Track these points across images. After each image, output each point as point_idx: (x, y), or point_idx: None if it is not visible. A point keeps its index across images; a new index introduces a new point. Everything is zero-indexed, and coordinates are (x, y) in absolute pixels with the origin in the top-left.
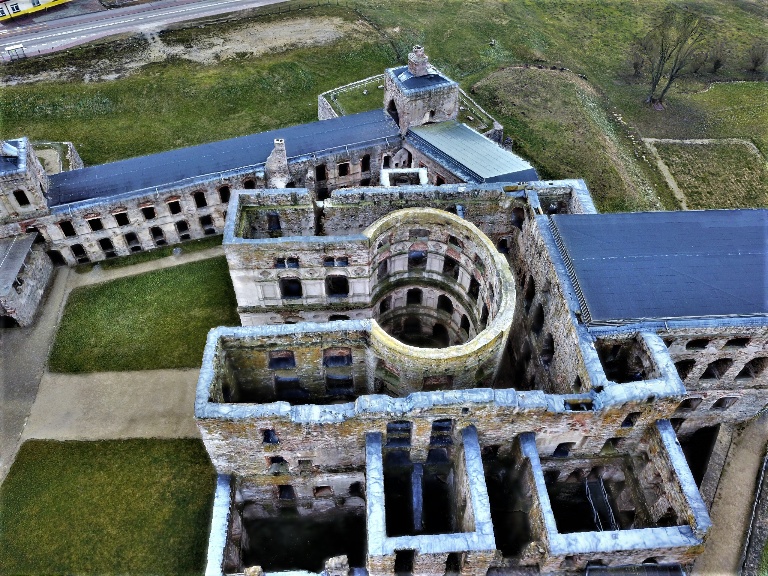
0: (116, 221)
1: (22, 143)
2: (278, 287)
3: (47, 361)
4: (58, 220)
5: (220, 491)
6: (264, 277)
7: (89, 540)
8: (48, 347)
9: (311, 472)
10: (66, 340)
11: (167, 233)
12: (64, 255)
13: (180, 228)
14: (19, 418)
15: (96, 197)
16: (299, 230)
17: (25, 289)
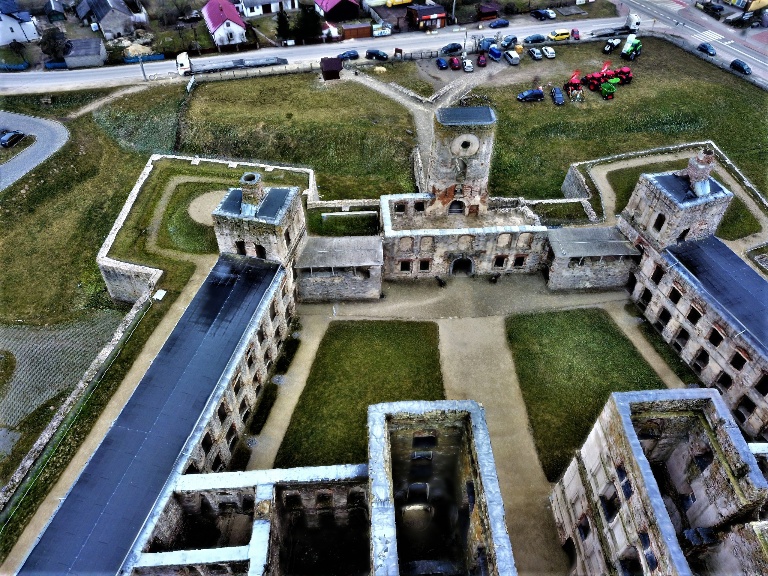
0: (689, 312)
1: (722, 194)
2: (608, 486)
3: (516, 314)
4: (659, 262)
5: (351, 468)
6: (607, 462)
7: (352, 391)
8: (531, 310)
9: (372, 561)
10: (542, 321)
11: (709, 368)
12: (636, 287)
13: (724, 380)
14: (456, 312)
15: (700, 280)
16: (712, 499)
17: (577, 270)
